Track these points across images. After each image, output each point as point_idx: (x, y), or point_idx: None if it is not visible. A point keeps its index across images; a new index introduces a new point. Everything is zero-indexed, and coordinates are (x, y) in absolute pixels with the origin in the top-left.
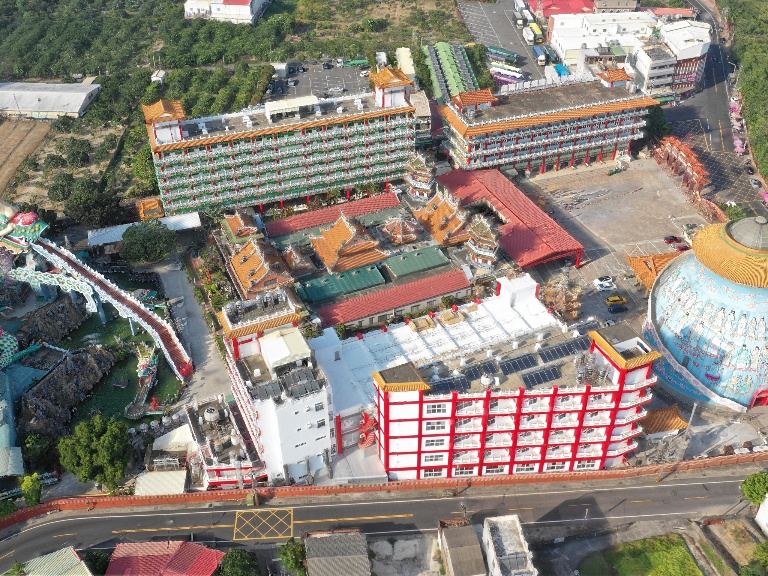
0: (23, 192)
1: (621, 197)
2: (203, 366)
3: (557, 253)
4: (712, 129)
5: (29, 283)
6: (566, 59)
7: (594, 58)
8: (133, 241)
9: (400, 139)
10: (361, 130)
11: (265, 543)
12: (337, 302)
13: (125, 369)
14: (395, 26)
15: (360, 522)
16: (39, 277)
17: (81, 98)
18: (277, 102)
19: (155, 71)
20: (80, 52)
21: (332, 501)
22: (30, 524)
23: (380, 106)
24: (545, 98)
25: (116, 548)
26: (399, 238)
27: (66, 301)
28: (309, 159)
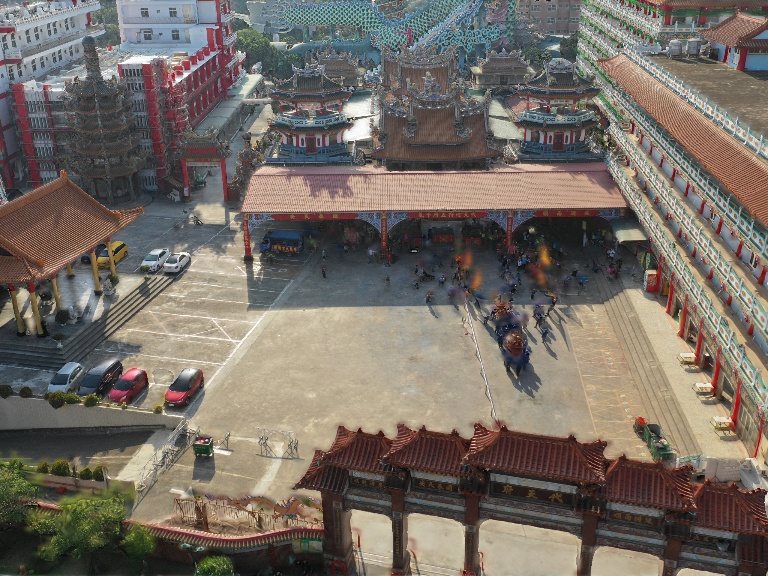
0: None
1: (480, 400)
2: None
3: None
4: None
5: None
6: None
7: None
8: None
9: None
10: None
11: None
12: (337, 108)
13: None
14: None
15: None
16: None
17: None
18: None
19: None
20: None
21: None
22: None
23: None
24: None
25: None
26: None
27: None
28: None
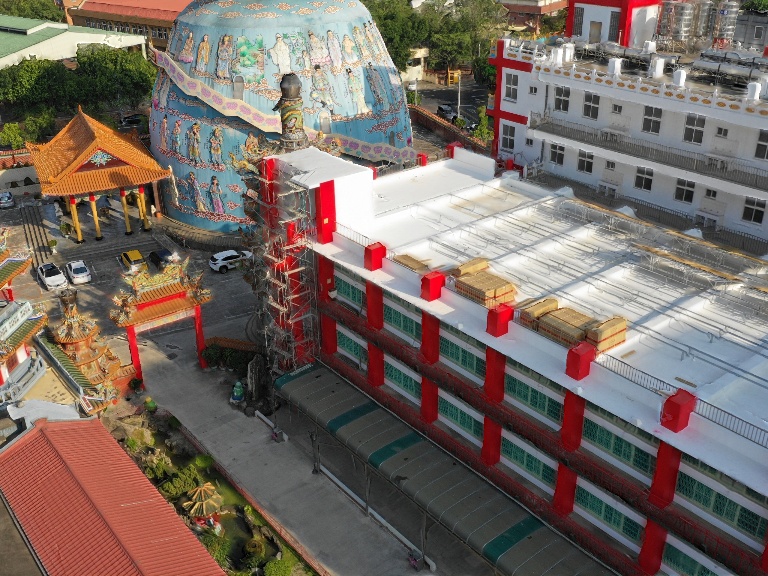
0: None
1: None
2: None
3: None
4: None
5: None
6: None
7: None
8: None
9: None
10: None
11: None
12: None
13: None
14: None
15: None
16: None
17: None
18: None
19: None
20: None
21: None
22: None
23: None
24: None
25: None
26: None
27: None
28: None
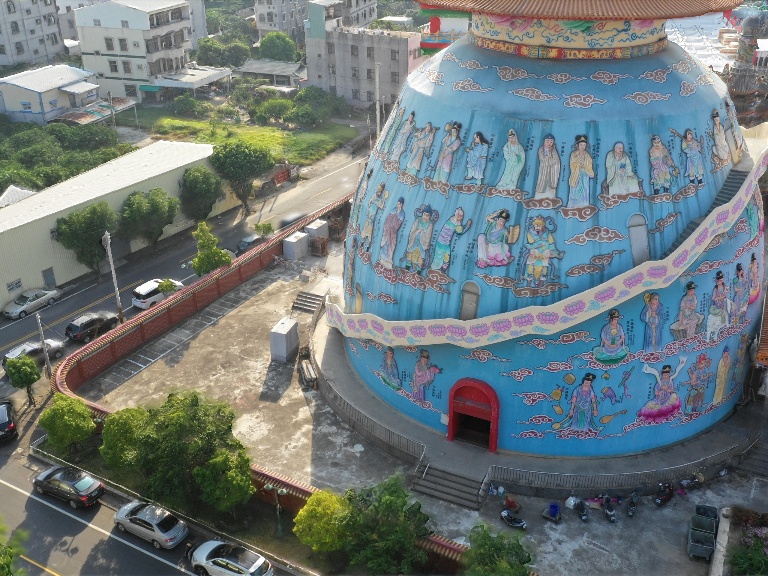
0: None
1: None
2: None
3: None
4: None
5: None
6: None
7: None
8: None
9: None
10: None
11: None
12: None
13: None
14: None
15: None
16: None
17: None
18: None
19: None
20: None
21: None
22: None
23: None
24: None
25: None
26: None
27: None
28: None
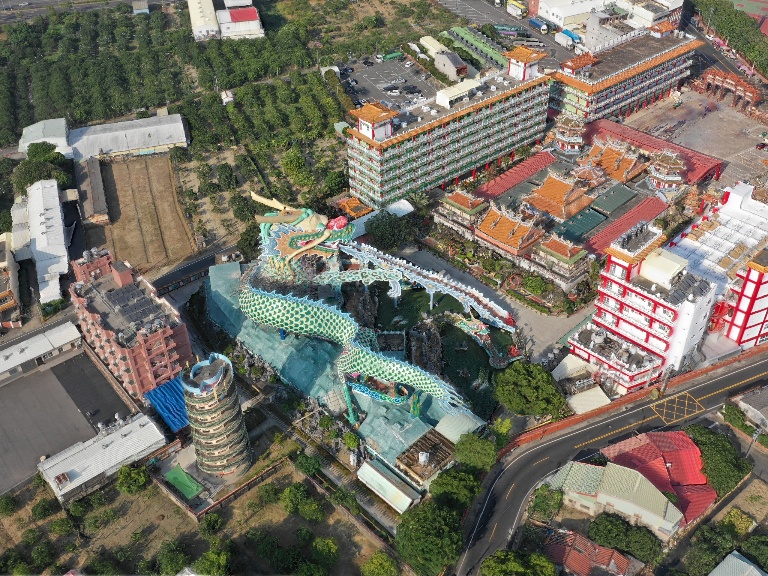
0: (203, 221)
1: (698, 123)
2: (517, 316)
3: (710, 169)
4: (714, 61)
5: (331, 285)
6: (565, 25)
7: (606, 19)
8: (383, 232)
9: (536, 106)
10: (516, 102)
11: (691, 420)
12: (584, 241)
13: (447, 337)
14: (390, 20)
15: (741, 386)
16: (343, 277)
17: (180, 128)
18: (449, 89)
19: (221, 93)
20: (125, 88)
21: (708, 379)
22: (505, 463)
23: (521, 80)
24: (624, 53)
25: (603, 452)
26: (593, 183)
27: (366, 293)
28: (480, 135)
